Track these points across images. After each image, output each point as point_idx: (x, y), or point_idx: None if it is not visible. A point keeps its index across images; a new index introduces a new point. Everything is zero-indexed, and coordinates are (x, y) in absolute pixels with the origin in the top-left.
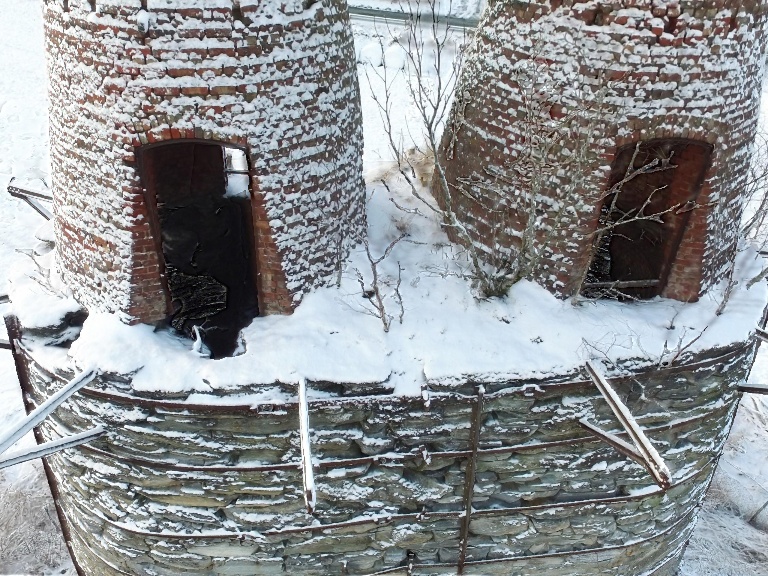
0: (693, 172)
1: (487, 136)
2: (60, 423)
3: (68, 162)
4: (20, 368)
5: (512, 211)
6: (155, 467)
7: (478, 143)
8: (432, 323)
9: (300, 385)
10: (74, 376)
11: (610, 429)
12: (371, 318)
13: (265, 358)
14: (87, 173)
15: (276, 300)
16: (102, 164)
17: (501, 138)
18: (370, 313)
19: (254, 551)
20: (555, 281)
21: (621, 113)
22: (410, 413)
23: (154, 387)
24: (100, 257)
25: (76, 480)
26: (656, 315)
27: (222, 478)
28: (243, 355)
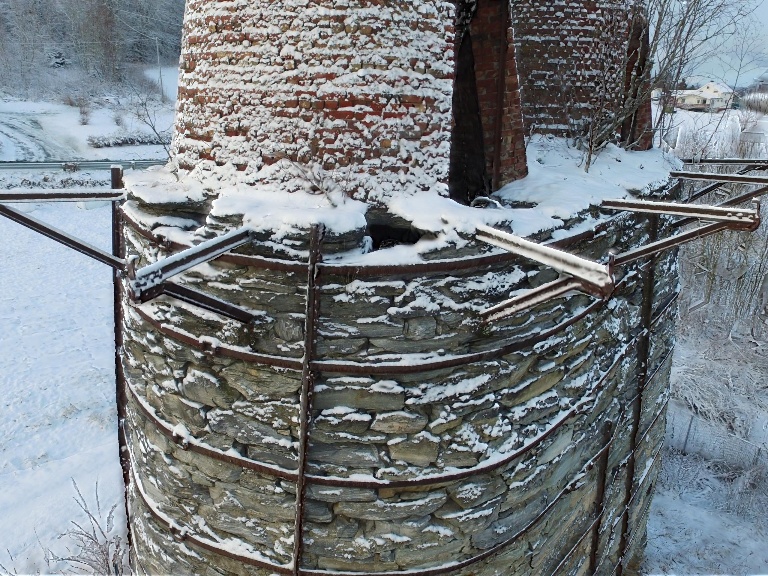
0: (635, 57)
1: (541, 39)
2: (404, 354)
3: (362, 13)
4: (313, 315)
5: (578, 88)
6: (522, 349)
7: (532, 47)
8: (598, 164)
9: (610, 200)
10: (457, 248)
11: (671, 235)
12: (569, 168)
13: (564, 195)
14: (397, 19)
15: (512, 165)
16: (420, 4)
17: (555, 36)
18: (579, 156)
19: (572, 435)
20: (616, 134)
21: (627, 4)
22: (636, 226)
23: (537, 227)
24: (411, 121)
25: (424, 436)
26: (654, 152)
27: (566, 337)
28: (546, 200)
